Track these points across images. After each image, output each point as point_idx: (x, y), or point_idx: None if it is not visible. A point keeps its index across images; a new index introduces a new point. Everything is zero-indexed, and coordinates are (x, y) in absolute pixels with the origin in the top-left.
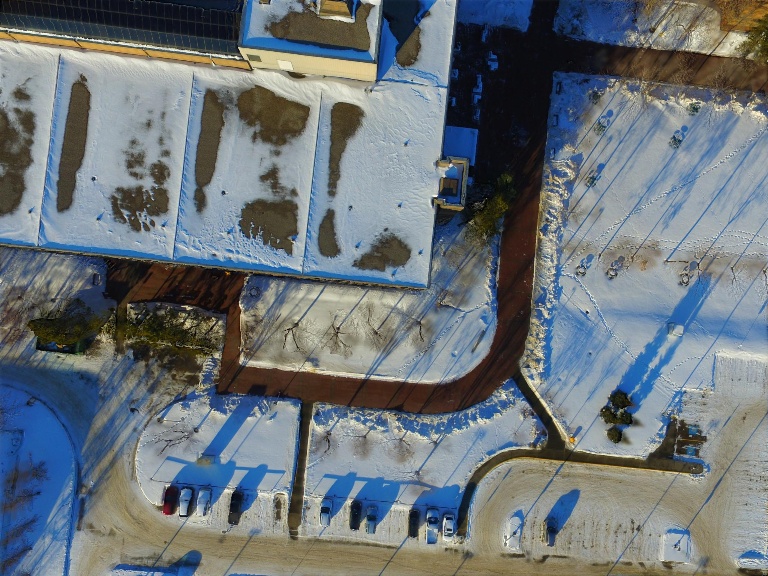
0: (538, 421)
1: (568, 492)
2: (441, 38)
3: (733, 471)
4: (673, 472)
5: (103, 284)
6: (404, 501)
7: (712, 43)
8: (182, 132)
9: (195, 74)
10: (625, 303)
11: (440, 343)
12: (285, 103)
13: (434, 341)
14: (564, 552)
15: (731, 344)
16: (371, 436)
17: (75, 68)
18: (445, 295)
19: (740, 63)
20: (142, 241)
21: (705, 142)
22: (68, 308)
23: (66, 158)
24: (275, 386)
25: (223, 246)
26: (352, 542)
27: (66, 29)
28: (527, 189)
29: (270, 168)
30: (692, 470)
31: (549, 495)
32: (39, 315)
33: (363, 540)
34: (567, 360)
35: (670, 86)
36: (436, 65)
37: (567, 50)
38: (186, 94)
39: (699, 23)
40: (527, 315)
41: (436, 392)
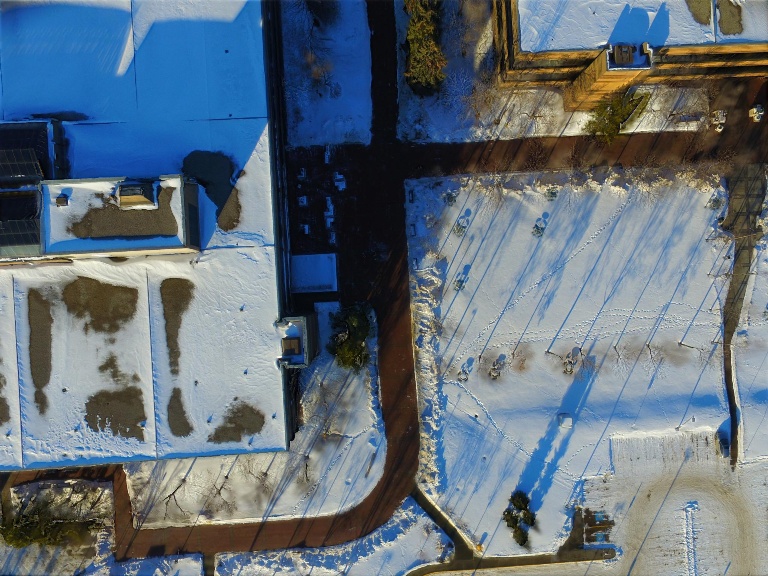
0: (442, 534)
1: None
2: (260, 196)
3: (646, 550)
4: (586, 561)
5: None
6: None
7: (559, 125)
8: (11, 337)
9: (14, 276)
10: (512, 401)
11: (332, 473)
12: (112, 289)
13: (325, 473)
14: None
15: (624, 425)
16: None
17: None
18: (329, 425)
19: (591, 140)
20: None
21: (568, 225)
22: None
23: None
24: (173, 544)
25: (72, 445)
26: None
27: None
28: (396, 303)
29: (107, 357)
30: (604, 556)
31: None
32: None
33: None
34: (462, 469)
35: (524, 175)
36: (259, 224)
37: (414, 156)
38: (9, 298)
39: (542, 109)
40: (416, 430)
41: (336, 522)
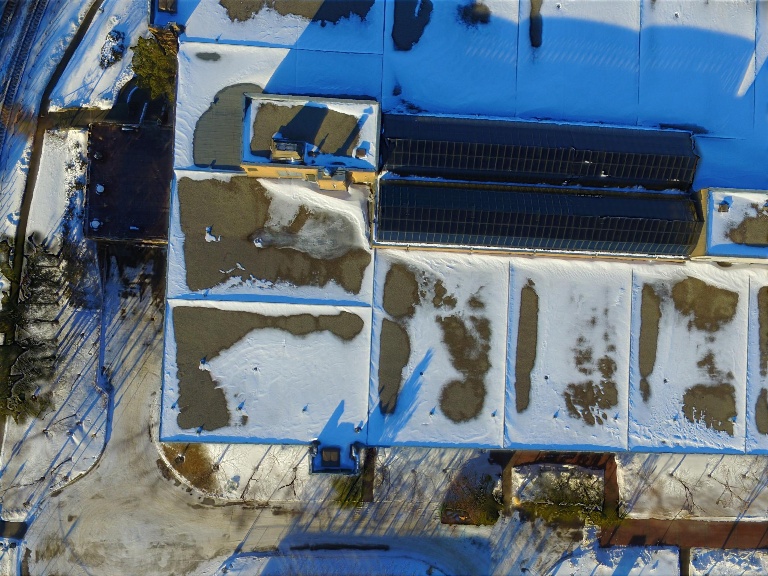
0: None
1: None
2: None
3: None
4: None
5: (489, 451)
6: None
7: None
8: (625, 327)
9: (634, 271)
10: None
11: None
12: (715, 291)
13: None
14: None
15: None
16: None
17: (523, 273)
18: None
19: None
20: (597, 434)
21: None
22: (482, 486)
23: (521, 360)
24: (654, 535)
25: (671, 433)
26: None
27: (529, 244)
28: None
29: (706, 354)
30: None
31: None
32: (431, 486)
33: None
34: None
35: None
36: None
37: None
38: (626, 290)
39: None
40: None
41: None
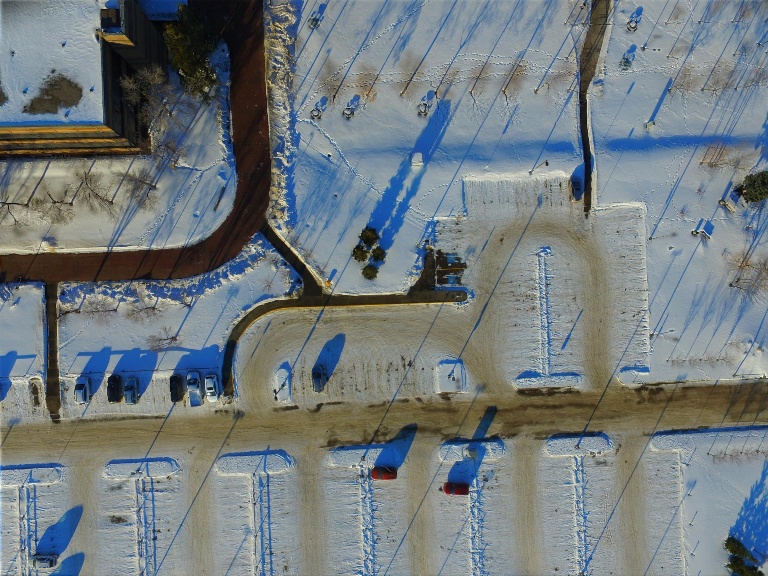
0: (291, 270)
1: (333, 337)
2: None
3: (498, 294)
4: (437, 303)
5: None
6: (163, 368)
7: None
8: None
9: None
10: (366, 141)
11: (180, 205)
12: None
13: (173, 204)
14: (338, 398)
15: (477, 167)
16: (121, 308)
17: None
18: (178, 156)
19: None
20: None
21: None
22: None
23: None
24: (15, 271)
25: None
26: (118, 418)
27: None
28: (250, 39)
29: None
30: (456, 298)
31: (313, 343)
32: None
33: (129, 414)
34: (312, 205)
35: None
36: None
37: None
38: None
39: None
40: (267, 166)
41: (183, 255)
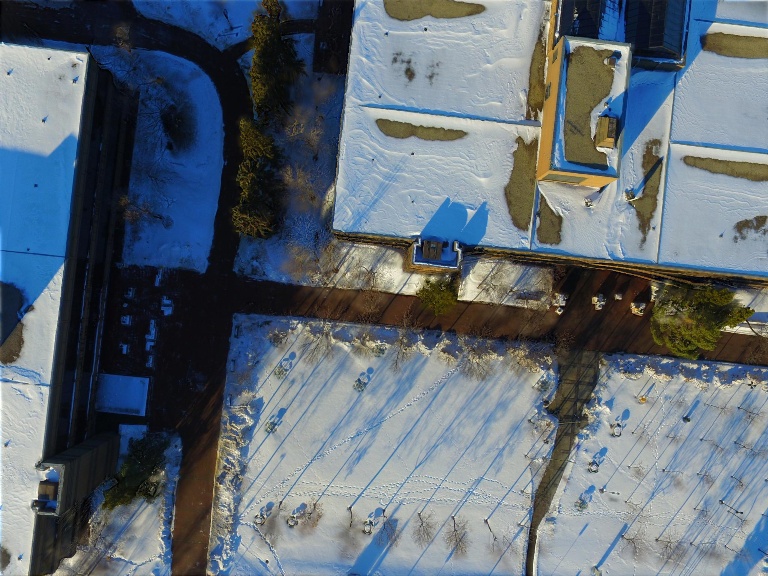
0: None
1: None
2: (45, 334)
3: None
4: None
5: None
6: None
7: (397, 284)
8: None
9: None
10: (306, 552)
11: None
12: None
13: None
14: None
15: None
16: None
17: None
18: (115, 548)
19: None
20: None
21: (391, 384)
22: None
23: None
24: None
25: None
26: None
27: None
28: (205, 436)
29: None
30: None
31: None
32: None
33: None
34: None
35: (356, 327)
36: (39, 362)
37: (248, 291)
38: None
39: (380, 266)
40: (203, 566)
41: None
